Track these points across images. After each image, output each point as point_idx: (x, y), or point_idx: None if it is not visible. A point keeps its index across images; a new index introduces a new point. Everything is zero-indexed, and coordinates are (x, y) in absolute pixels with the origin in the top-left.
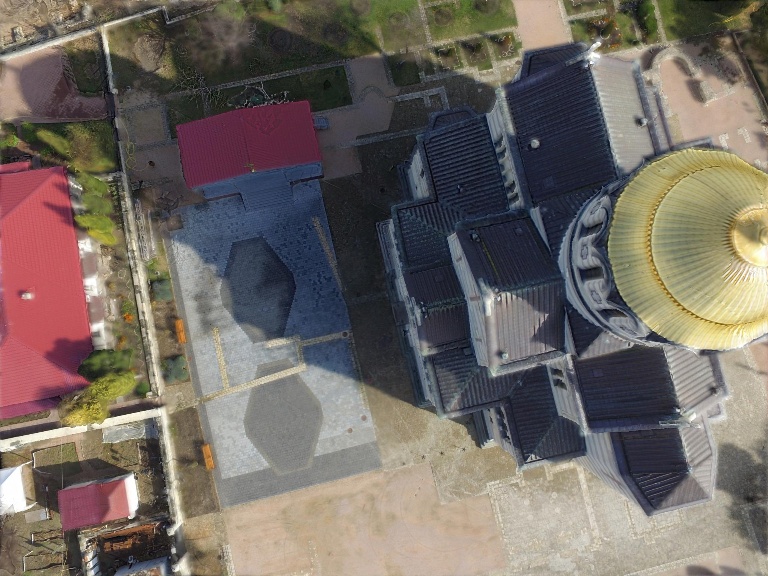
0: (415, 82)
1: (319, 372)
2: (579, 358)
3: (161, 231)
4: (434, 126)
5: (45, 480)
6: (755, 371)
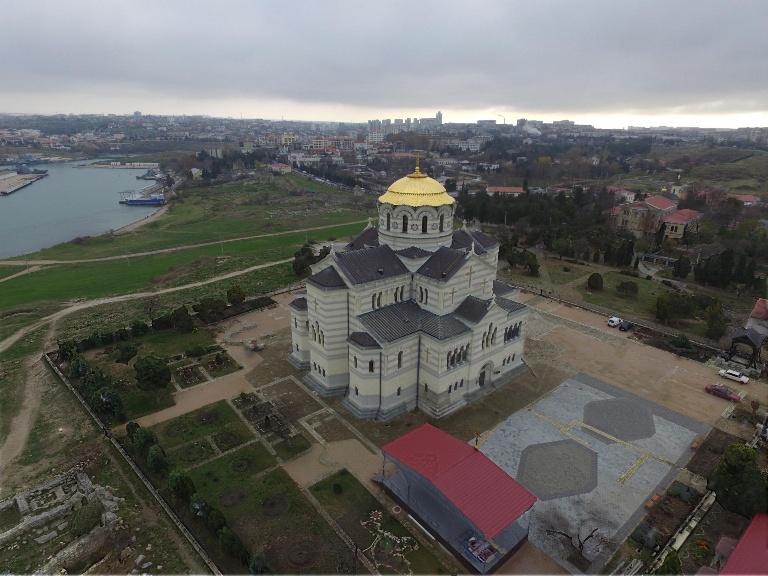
0: (301, 437)
1: (568, 413)
2: None
3: (600, 571)
4: (371, 345)
5: None
6: None
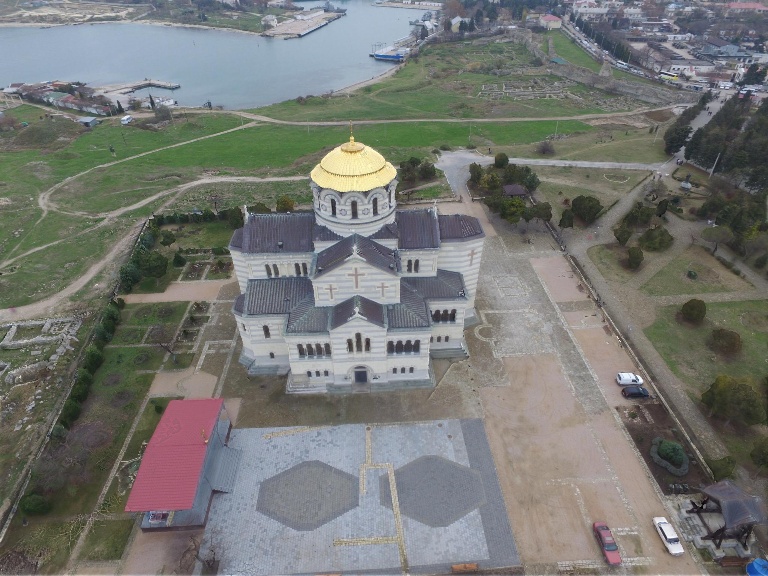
0: (192, 356)
1: (396, 453)
2: None
3: None
4: (240, 311)
5: None
6: None
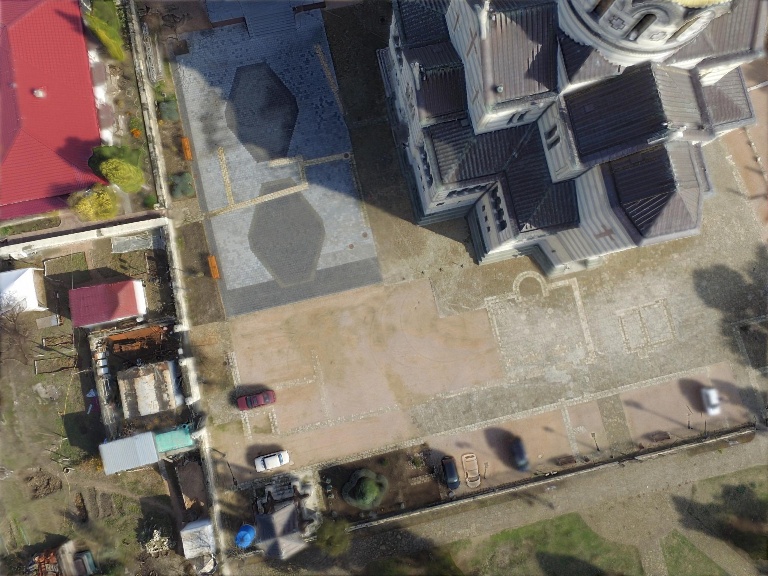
0: None
1: (321, 191)
2: (571, 84)
3: (167, 55)
4: None
5: (56, 287)
6: (746, 197)
